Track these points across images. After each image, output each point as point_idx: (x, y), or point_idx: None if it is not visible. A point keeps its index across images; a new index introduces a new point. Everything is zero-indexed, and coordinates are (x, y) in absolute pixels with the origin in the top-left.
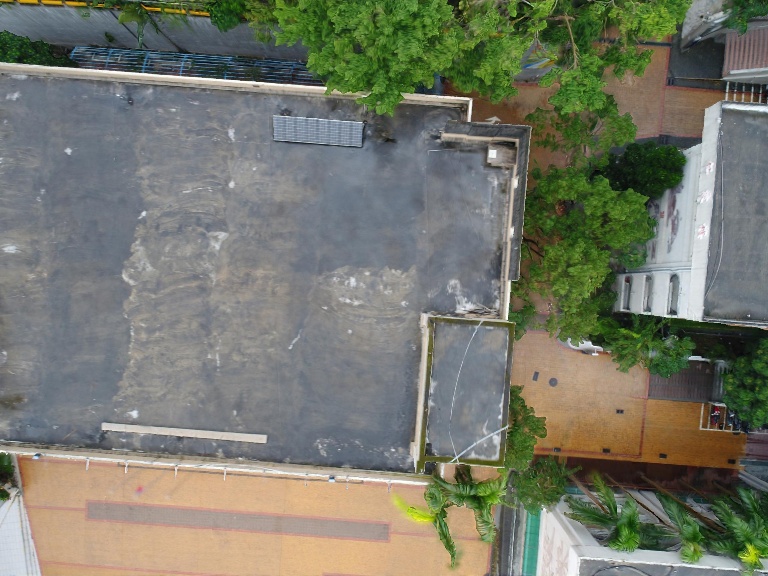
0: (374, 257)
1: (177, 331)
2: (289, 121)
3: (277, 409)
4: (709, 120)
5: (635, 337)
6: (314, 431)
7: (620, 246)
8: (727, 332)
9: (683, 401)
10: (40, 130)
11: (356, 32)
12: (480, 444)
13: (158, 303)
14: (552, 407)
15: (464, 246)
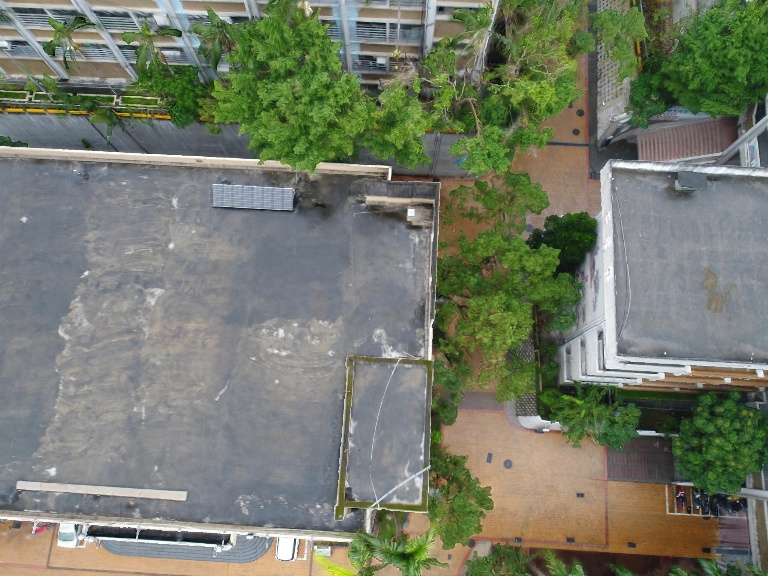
0: (302, 309)
1: (106, 384)
2: (227, 189)
3: (200, 463)
4: (604, 178)
5: (578, 403)
6: (237, 487)
7: (547, 306)
8: (678, 406)
9: (645, 482)
10: (1, 202)
11: (278, 102)
12: (402, 487)
13: (90, 357)
14: (509, 491)
15: (389, 297)
